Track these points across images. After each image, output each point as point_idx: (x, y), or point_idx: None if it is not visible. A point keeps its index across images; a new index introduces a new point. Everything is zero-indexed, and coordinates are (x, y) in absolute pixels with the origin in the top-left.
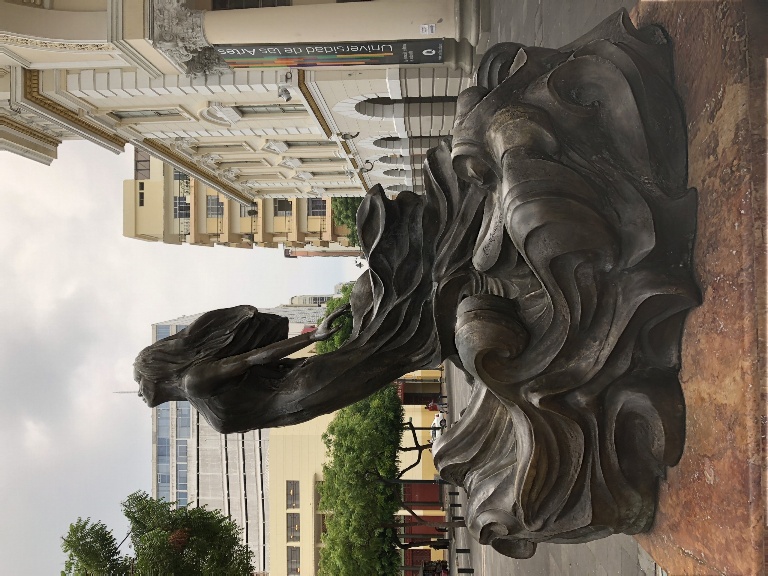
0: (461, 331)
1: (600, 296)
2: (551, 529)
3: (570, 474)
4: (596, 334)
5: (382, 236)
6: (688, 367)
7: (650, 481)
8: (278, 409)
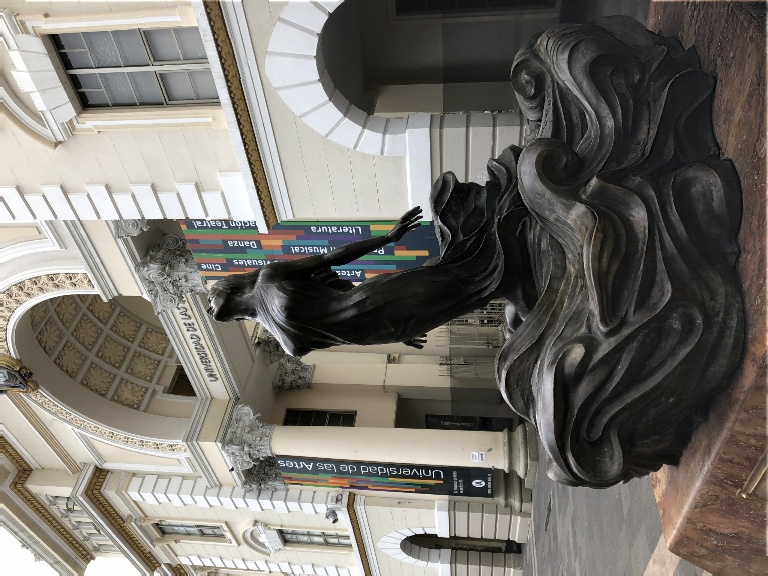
0: (522, 153)
1: (635, 102)
2: (631, 324)
3: (639, 250)
4: (639, 138)
5: (452, 194)
6: (724, 134)
7: (726, 267)
8: (342, 303)
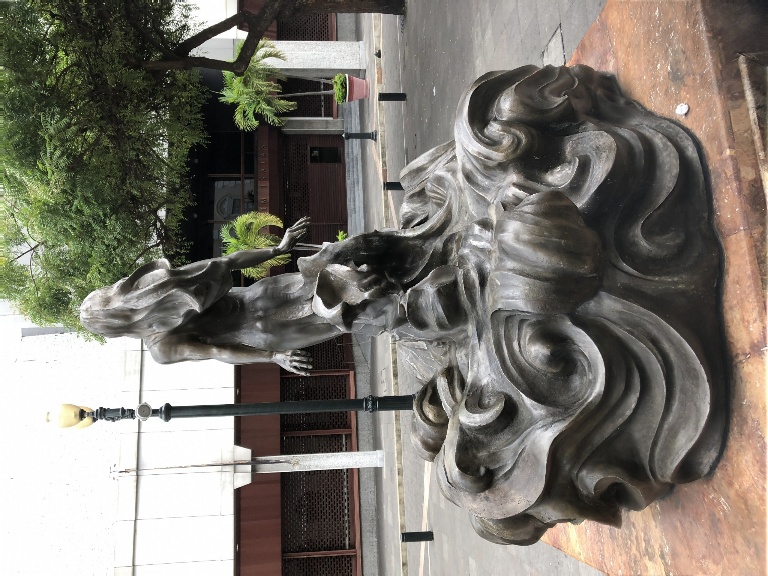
0: None
1: None
2: None
3: None
4: None
5: None
6: None
7: None
8: None
